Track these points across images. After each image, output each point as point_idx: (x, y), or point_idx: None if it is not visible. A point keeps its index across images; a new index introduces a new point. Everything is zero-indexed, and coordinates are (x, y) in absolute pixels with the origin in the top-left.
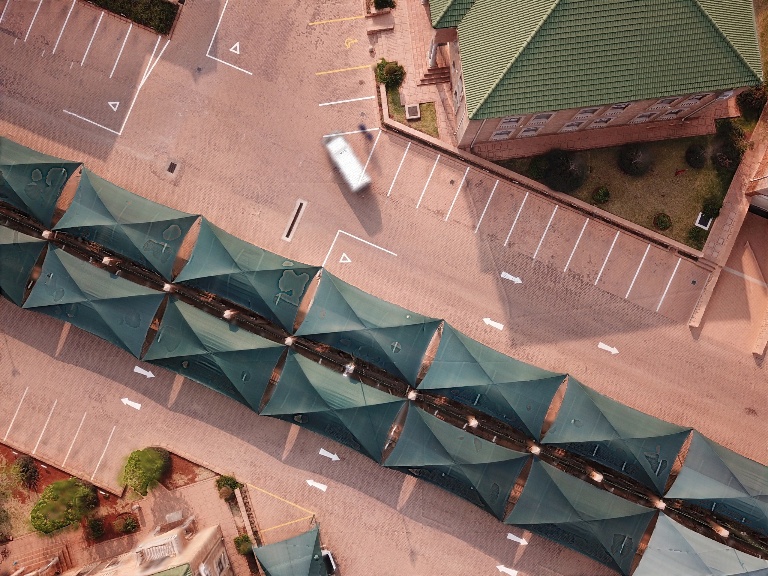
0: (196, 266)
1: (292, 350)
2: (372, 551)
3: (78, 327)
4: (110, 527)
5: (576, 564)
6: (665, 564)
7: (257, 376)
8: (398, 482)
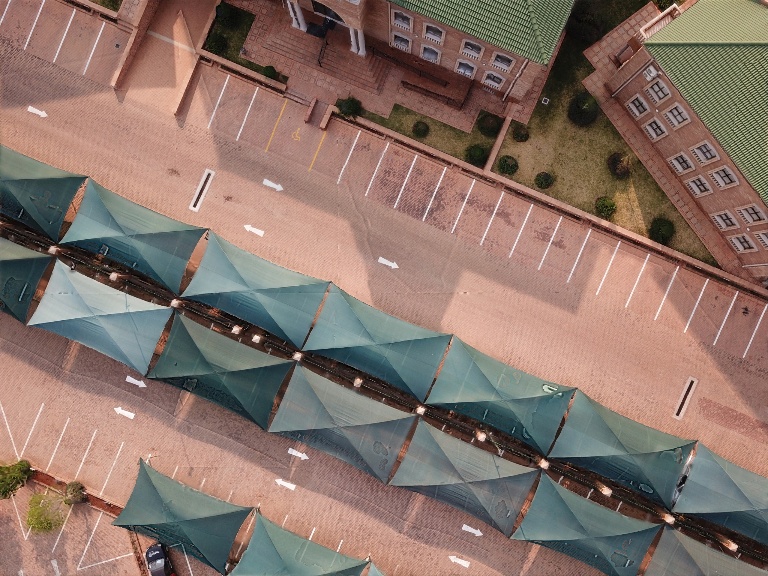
0: None
1: None
2: None
3: None
4: None
5: (8, 324)
6: (54, 307)
7: None
8: None
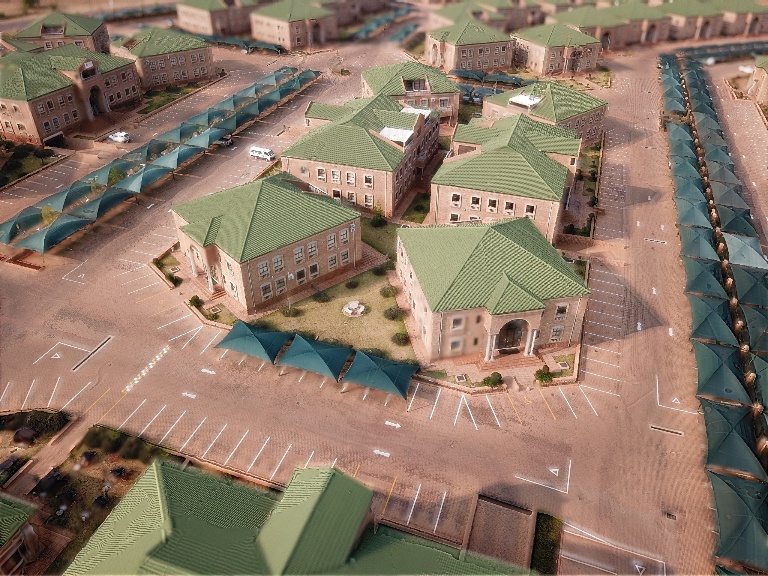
0: (748, 465)
1: (764, 409)
2: None
3: None
4: None
5: None
6: (754, 259)
7: None
8: None
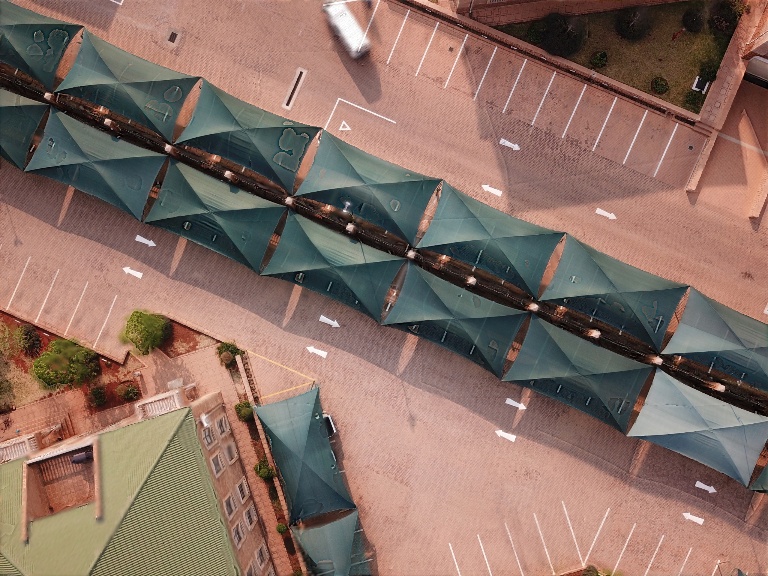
0: (197, 126)
1: (292, 211)
2: (372, 417)
3: (80, 190)
4: (112, 395)
5: (574, 428)
6: (662, 419)
7: (258, 236)
8: (397, 348)
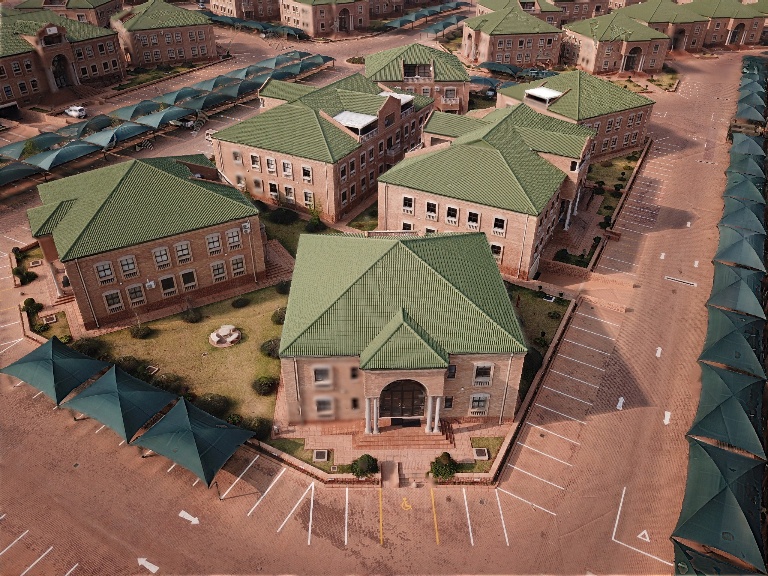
0: None
1: None
2: None
3: None
4: None
5: None
6: None
7: None
8: None
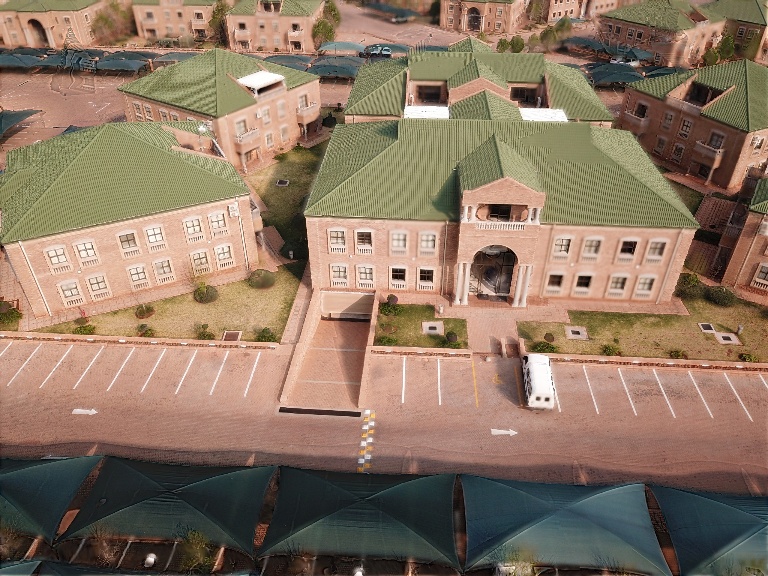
0: None
1: None
2: None
3: None
4: None
5: None
6: None
7: None
8: None
